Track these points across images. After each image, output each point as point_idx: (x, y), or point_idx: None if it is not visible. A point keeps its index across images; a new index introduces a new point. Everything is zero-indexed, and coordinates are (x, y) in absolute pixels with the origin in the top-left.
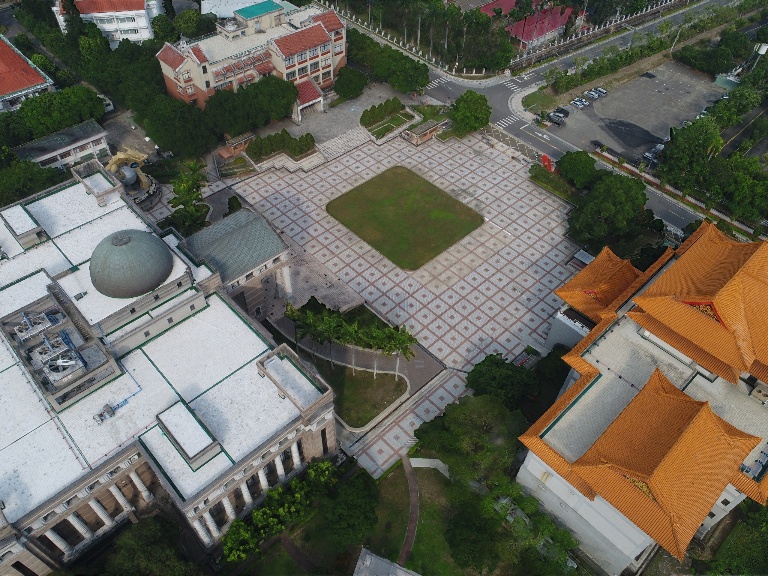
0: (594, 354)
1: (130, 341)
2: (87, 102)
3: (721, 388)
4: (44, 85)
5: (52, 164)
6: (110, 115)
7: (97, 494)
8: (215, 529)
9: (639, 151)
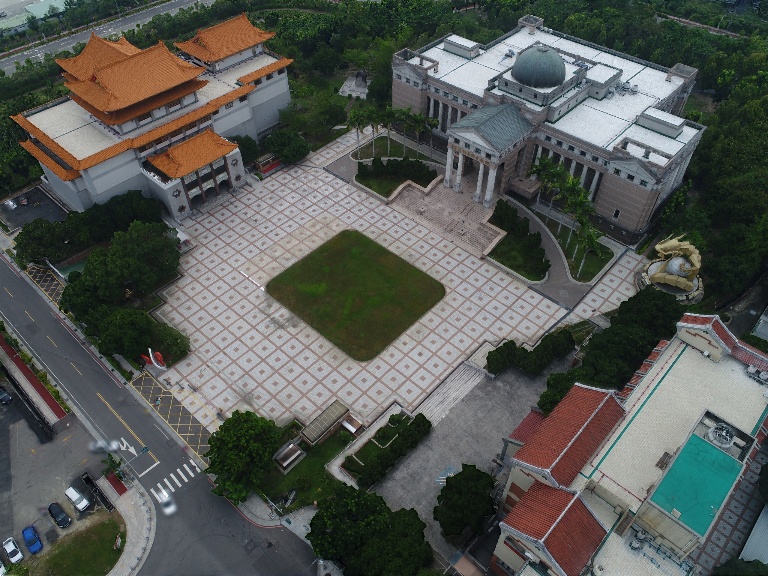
0: None
1: None
2: None
3: None
4: None
5: None
6: None
7: None
8: None
9: None
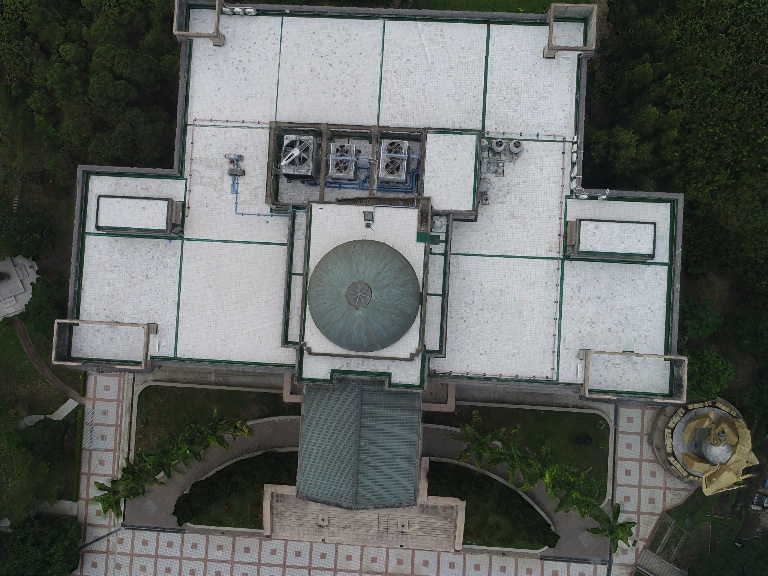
0: None
1: None
2: None
3: None
4: None
5: None
6: None
7: None
8: None
9: None
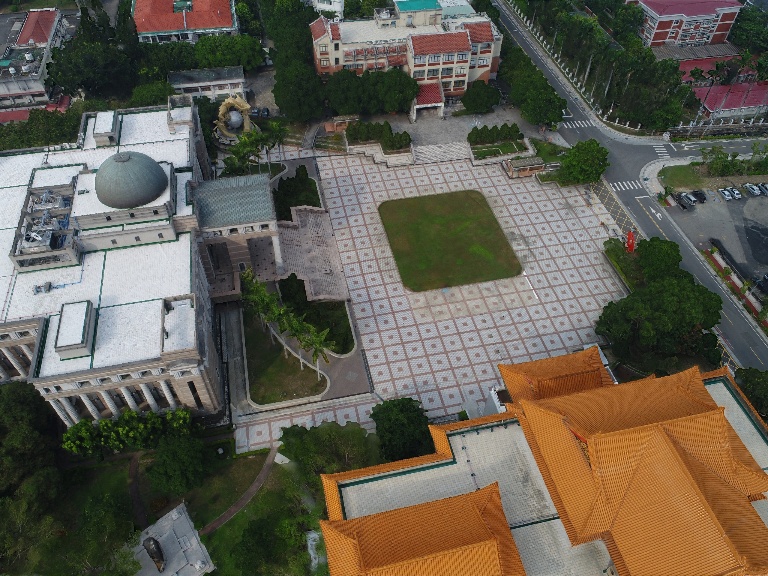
0: (467, 439)
1: (98, 242)
2: (248, 51)
3: (577, 546)
4: (229, 29)
5: (193, 93)
6: (269, 68)
7: (8, 345)
8: (75, 418)
9: (765, 270)
